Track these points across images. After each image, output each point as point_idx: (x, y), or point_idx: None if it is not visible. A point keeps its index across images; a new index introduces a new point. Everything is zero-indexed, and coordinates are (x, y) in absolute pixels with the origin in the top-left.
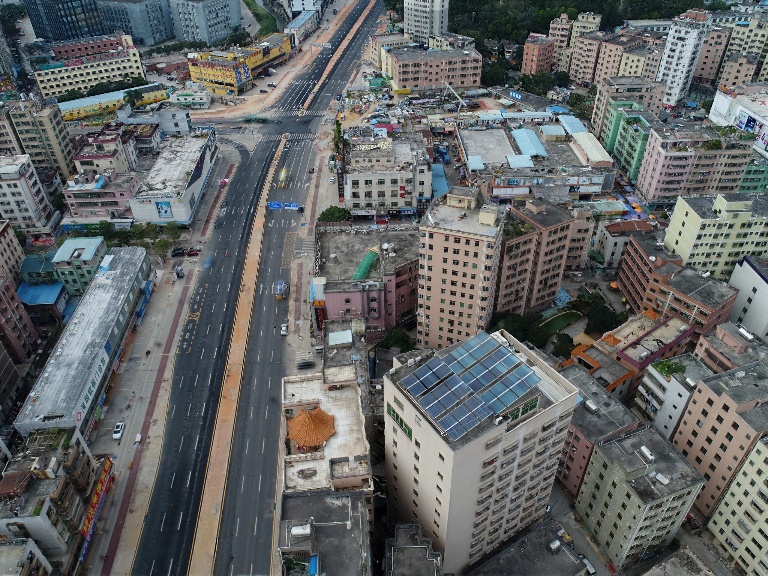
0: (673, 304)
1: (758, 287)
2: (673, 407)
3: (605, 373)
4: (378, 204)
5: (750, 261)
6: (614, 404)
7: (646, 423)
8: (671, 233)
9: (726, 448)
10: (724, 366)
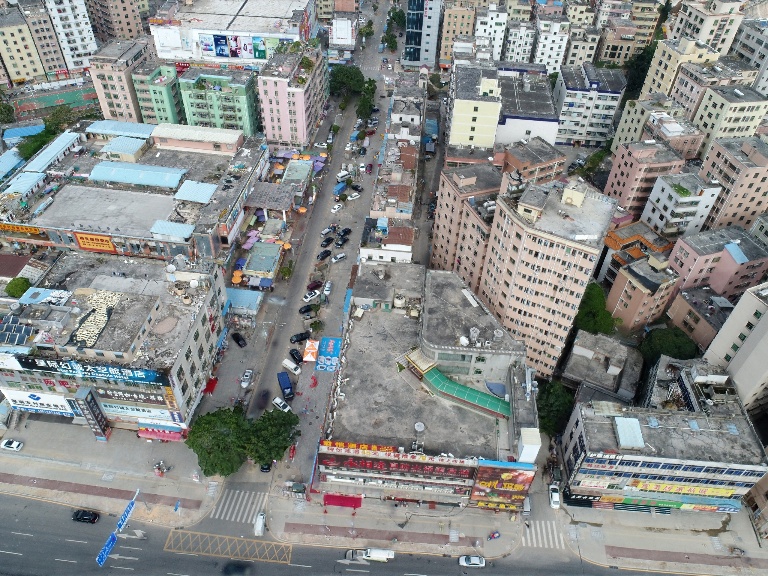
0: (540, 175)
1: (532, 128)
2: (706, 208)
3: (645, 236)
4: (201, 369)
5: (513, 116)
6: (721, 233)
7: (676, 239)
8: (459, 135)
9: (767, 192)
10: (665, 168)
